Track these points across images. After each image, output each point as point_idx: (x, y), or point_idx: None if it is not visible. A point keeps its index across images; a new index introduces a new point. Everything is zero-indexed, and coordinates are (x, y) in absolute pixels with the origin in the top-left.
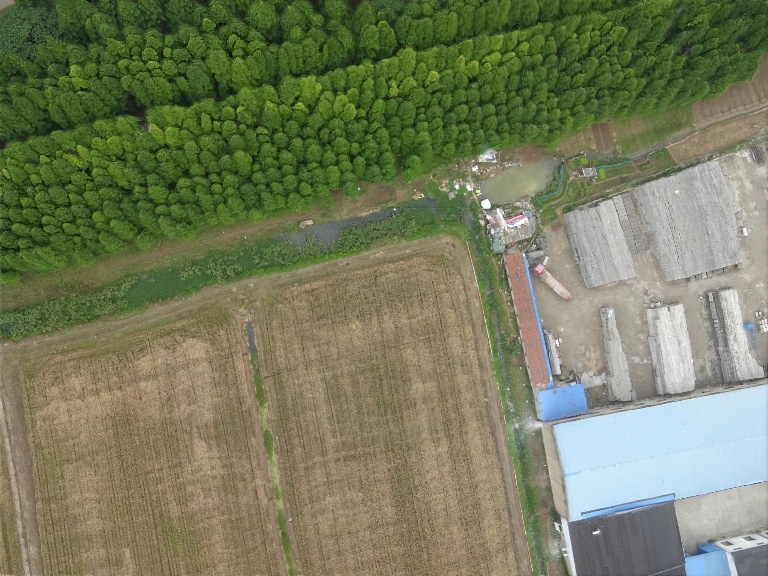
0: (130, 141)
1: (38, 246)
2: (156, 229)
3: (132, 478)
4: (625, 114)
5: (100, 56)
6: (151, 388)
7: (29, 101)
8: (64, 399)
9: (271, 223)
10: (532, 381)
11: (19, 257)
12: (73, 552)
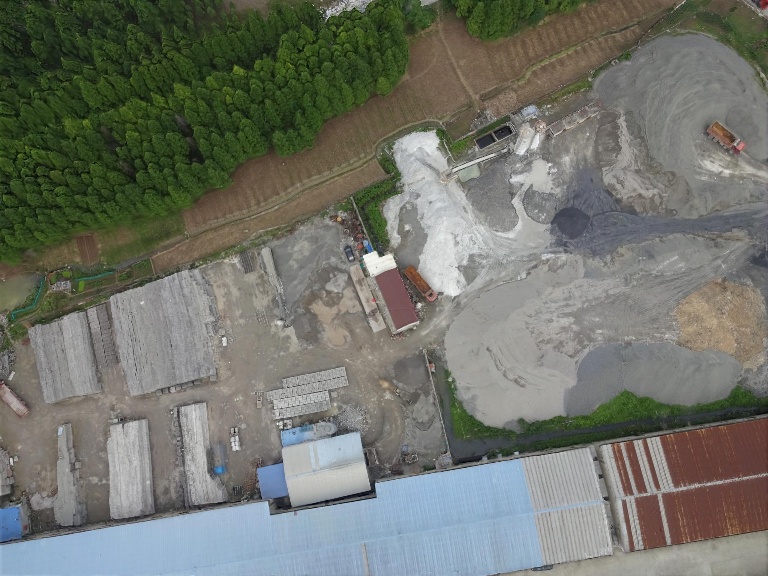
0: None
1: None
2: None
3: None
4: (94, 227)
5: None
6: None
7: None
8: None
9: None
10: None
11: None
12: None
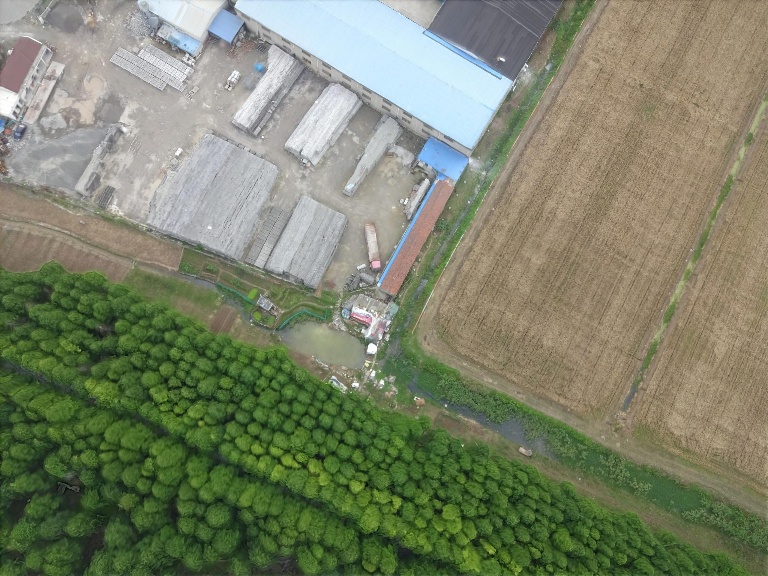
0: None
1: None
2: None
3: None
4: None
5: None
6: (727, 421)
7: None
8: None
9: (552, 475)
10: None
11: None
12: None
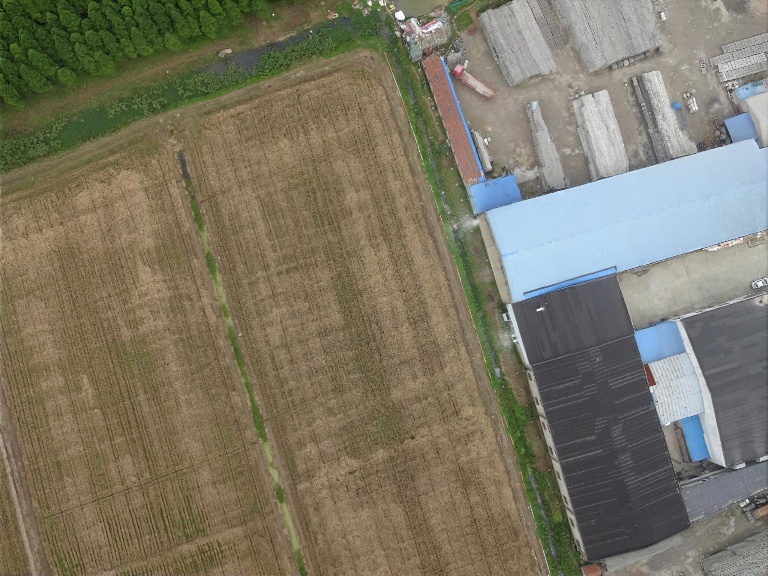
0: None
1: None
2: (76, 63)
3: (82, 308)
4: None
5: None
6: (91, 221)
7: None
8: (9, 239)
9: (191, 56)
10: (463, 178)
11: None
12: (33, 382)
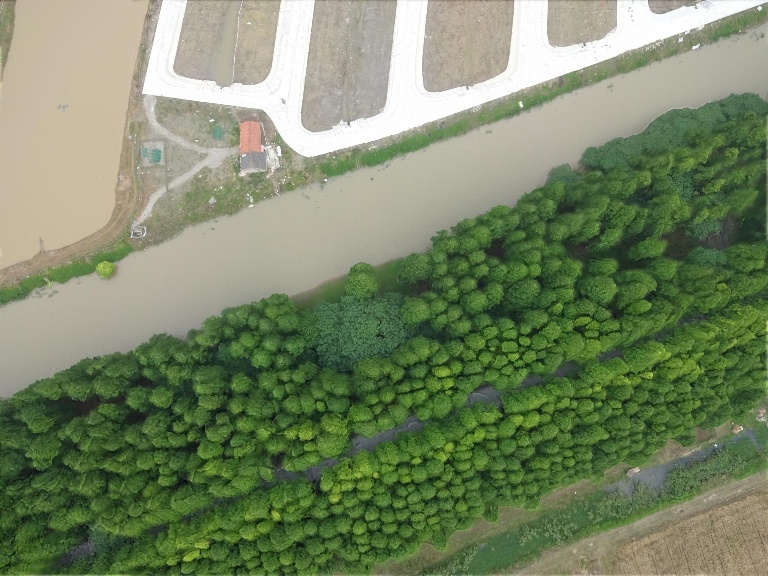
0: (495, 432)
1: (404, 541)
2: None
3: None
4: None
5: (462, 353)
6: None
7: (403, 407)
8: None
9: None
10: None
11: (388, 555)
12: None
